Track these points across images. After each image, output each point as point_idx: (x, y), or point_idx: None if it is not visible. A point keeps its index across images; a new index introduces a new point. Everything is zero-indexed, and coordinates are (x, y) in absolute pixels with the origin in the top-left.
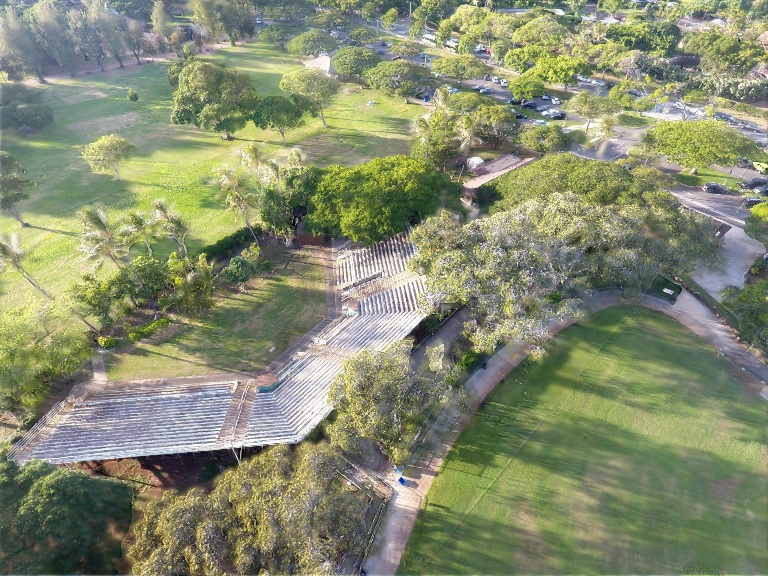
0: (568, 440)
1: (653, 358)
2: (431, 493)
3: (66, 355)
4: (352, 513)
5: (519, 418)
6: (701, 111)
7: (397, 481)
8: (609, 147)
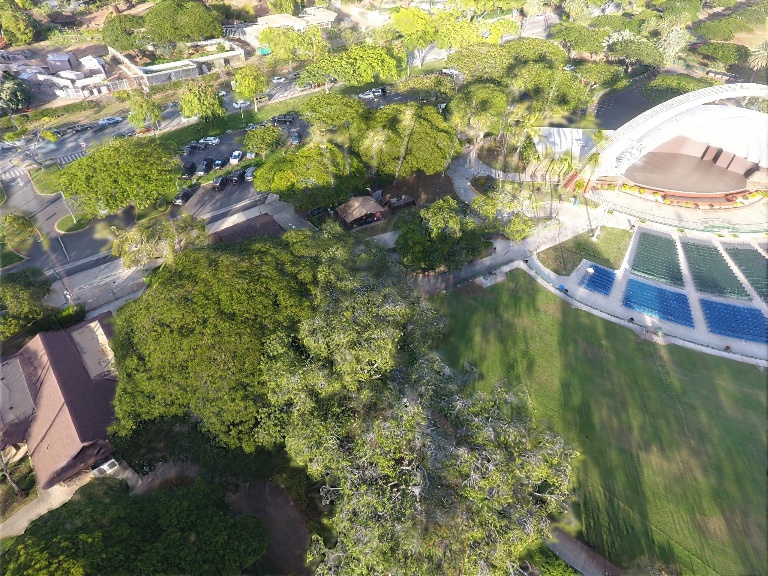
0: (598, 456)
1: (465, 343)
2: None
3: None
4: None
5: (594, 502)
6: (17, 141)
7: None
8: (33, 243)
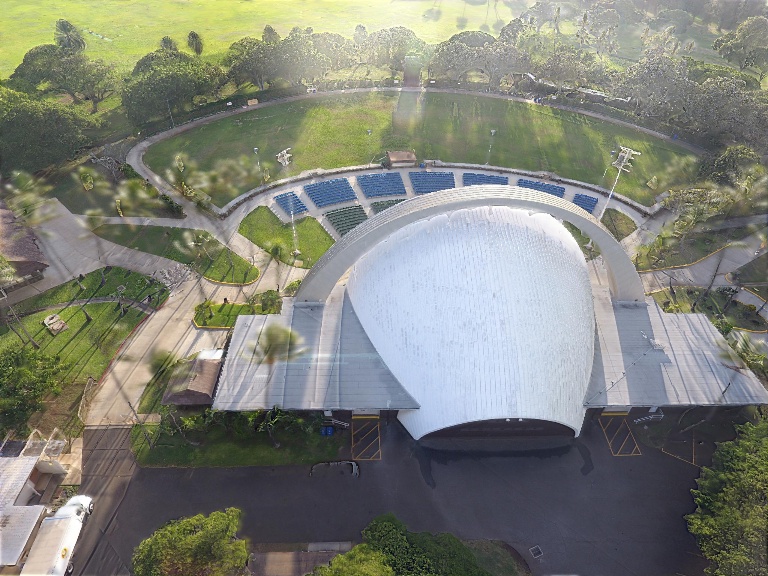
0: None
1: (659, 159)
2: (535, 104)
3: (540, 60)
4: (514, 54)
5: None
6: None
7: (535, 99)
8: None
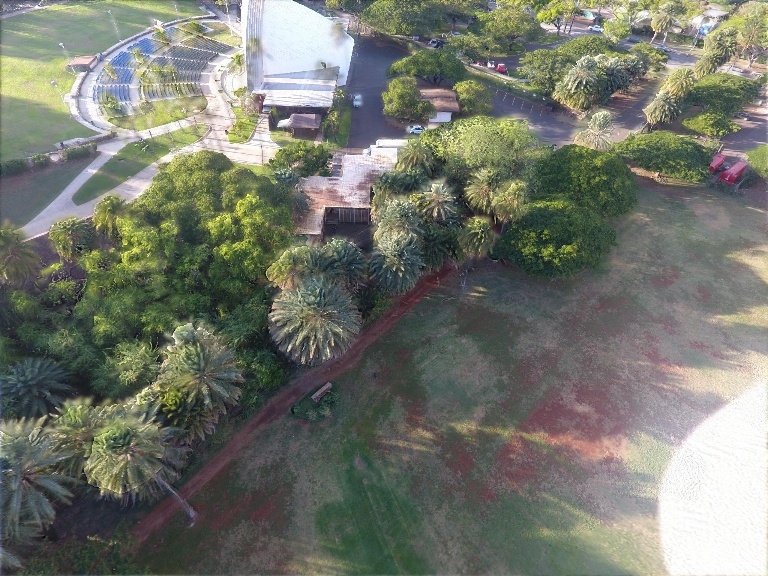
0: None
1: None
2: (46, 7)
3: None
4: None
5: None
6: None
7: (37, 5)
8: None
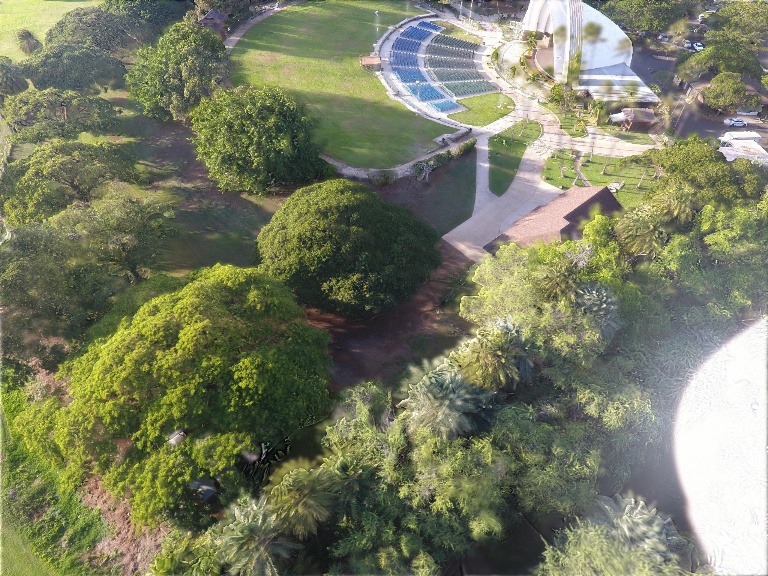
0: (336, 6)
1: None
2: None
3: None
4: None
5: (321, 2)
6: None
7: (276, 7)
8: None
